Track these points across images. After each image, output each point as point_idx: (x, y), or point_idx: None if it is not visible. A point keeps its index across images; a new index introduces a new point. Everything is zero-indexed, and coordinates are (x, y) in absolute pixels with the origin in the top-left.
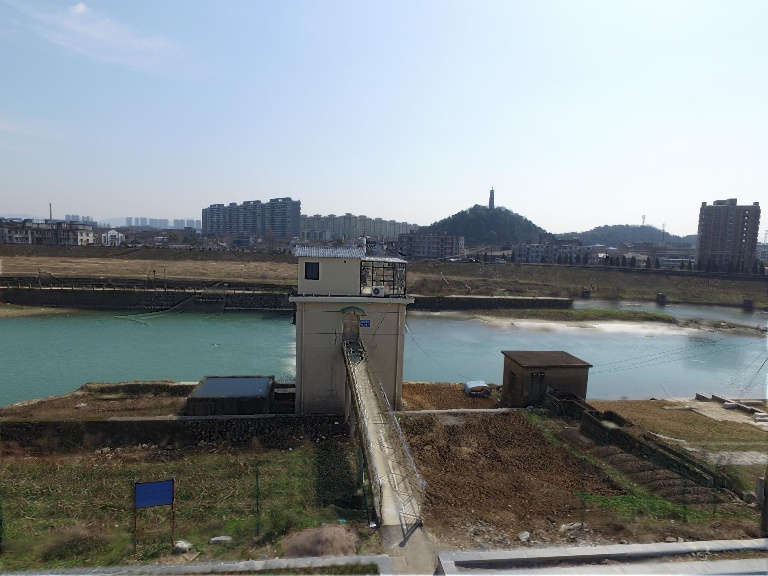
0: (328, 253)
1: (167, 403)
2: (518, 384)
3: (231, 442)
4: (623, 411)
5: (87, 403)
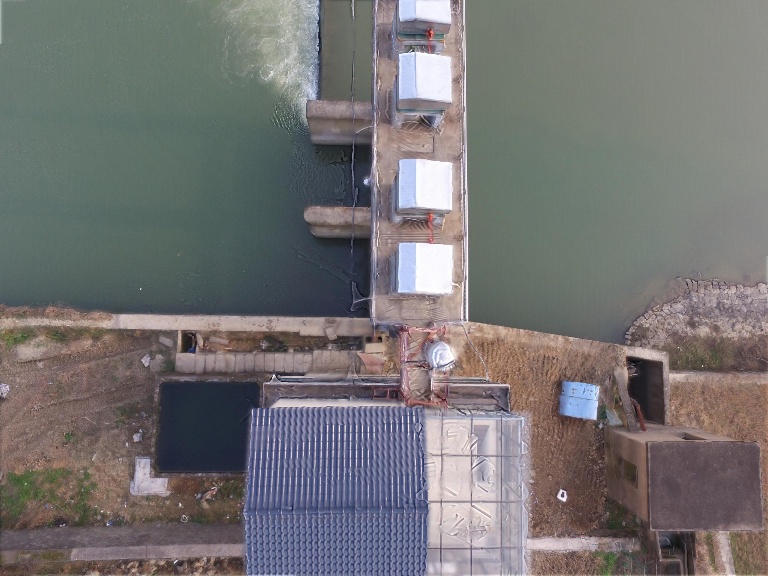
0: (330, 569)
1: (120, 376)
2: (630, 497)
3: (231, 565)
4: (766, 455)
5: (8, 382)
